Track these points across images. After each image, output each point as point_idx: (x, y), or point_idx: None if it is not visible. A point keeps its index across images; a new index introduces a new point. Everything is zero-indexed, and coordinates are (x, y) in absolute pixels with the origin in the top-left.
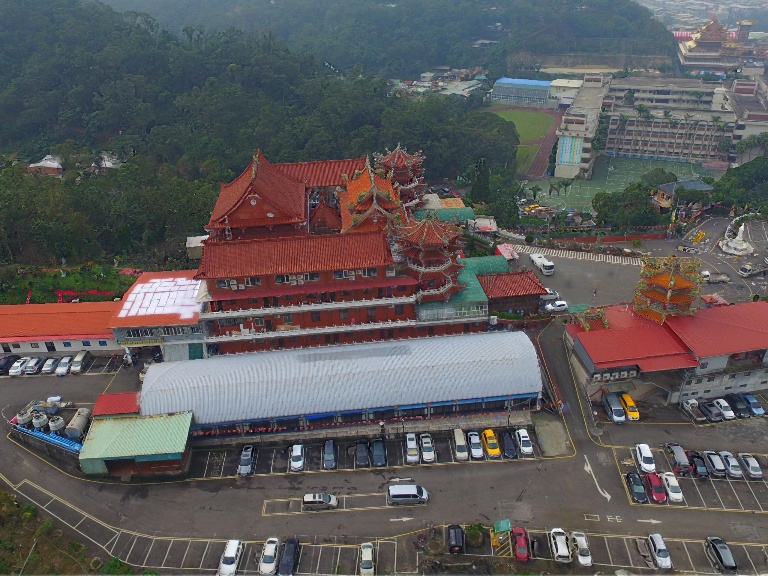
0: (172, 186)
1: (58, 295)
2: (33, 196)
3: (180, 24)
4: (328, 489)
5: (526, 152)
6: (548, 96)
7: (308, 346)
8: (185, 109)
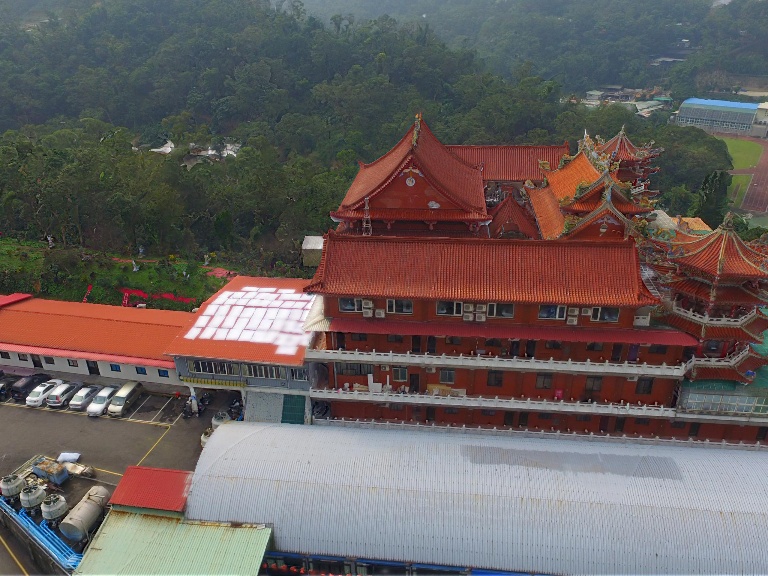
0: (294, 167)
1: (124, 295)
2: (118, 162)
3: (329, 12)
4: None
5: (734, 182)
6: (754, 121)
7: (474, 425)
8: (323, 100)
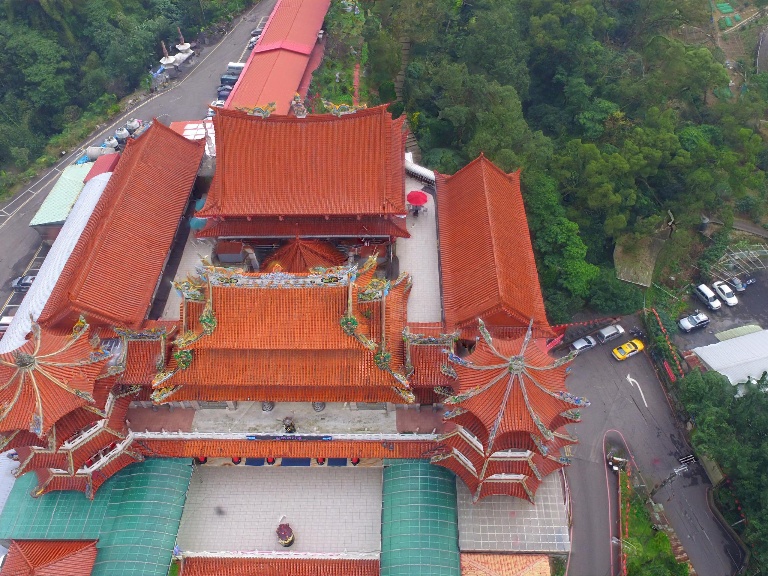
0: None
1: None
2: None
3: None
4: None
5: None
6: None
7: None
8: None
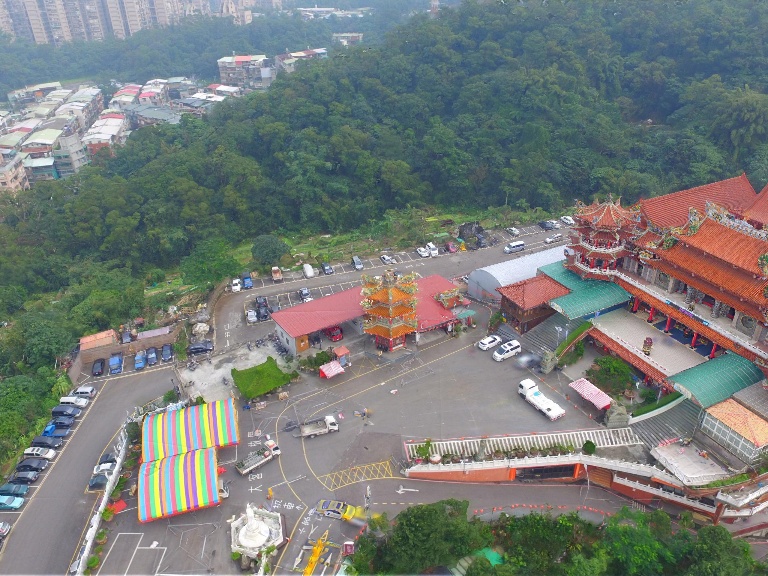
0: None
1: None
2: None
3: None
4: (557, 245)
5: None
6: None
7: None
8: None
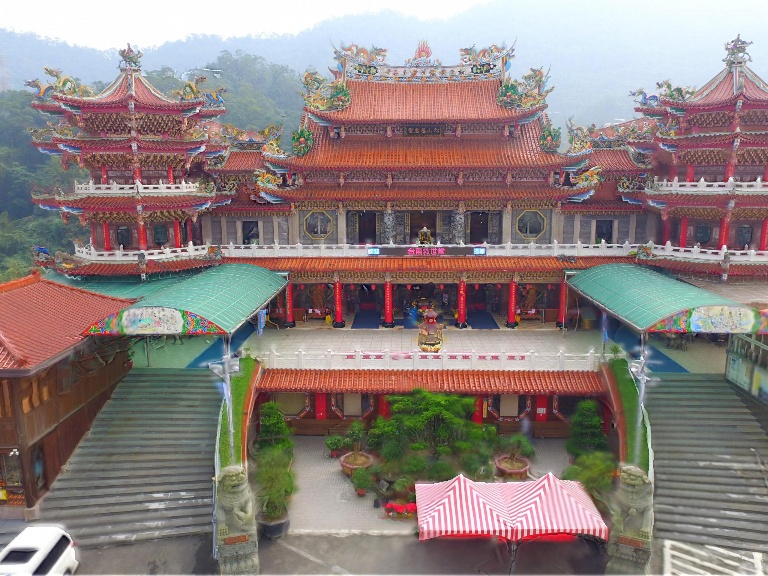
0: None
1: None
2: None
3: None
4: None
5: None
6: None
7: None
8: None
